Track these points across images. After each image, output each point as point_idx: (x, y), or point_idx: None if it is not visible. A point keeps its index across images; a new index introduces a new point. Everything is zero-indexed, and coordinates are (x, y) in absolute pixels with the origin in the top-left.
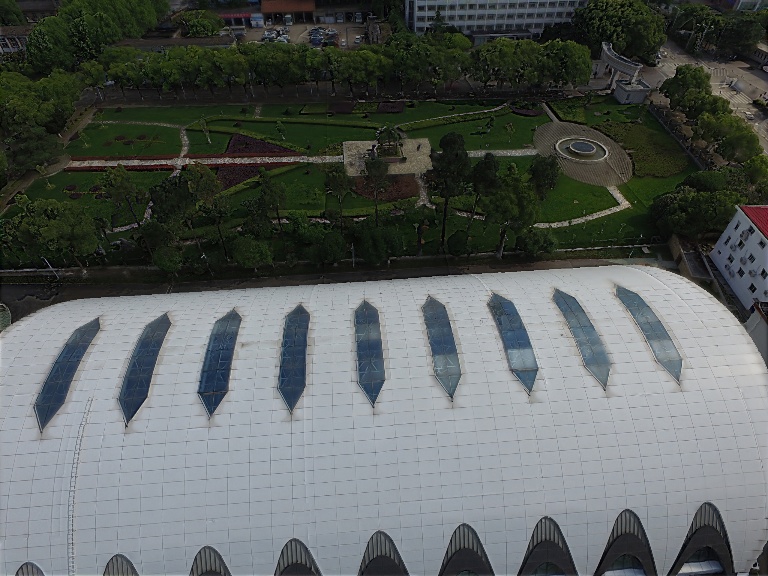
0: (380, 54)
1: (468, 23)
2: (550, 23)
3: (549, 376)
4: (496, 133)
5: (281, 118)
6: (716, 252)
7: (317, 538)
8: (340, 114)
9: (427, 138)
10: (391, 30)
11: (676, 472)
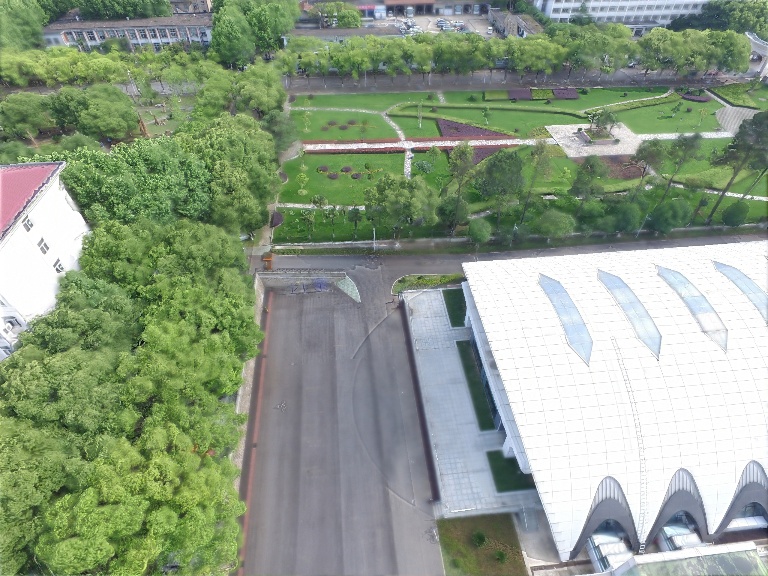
0: (556, 43)
1: (600, 14)
2: (676, 15)
3: None
4: (680, 117)
5: (468, 104)
6: None
7: None
8: (522, 100)
9: (621, 122)
10: (535, 21)
11: None
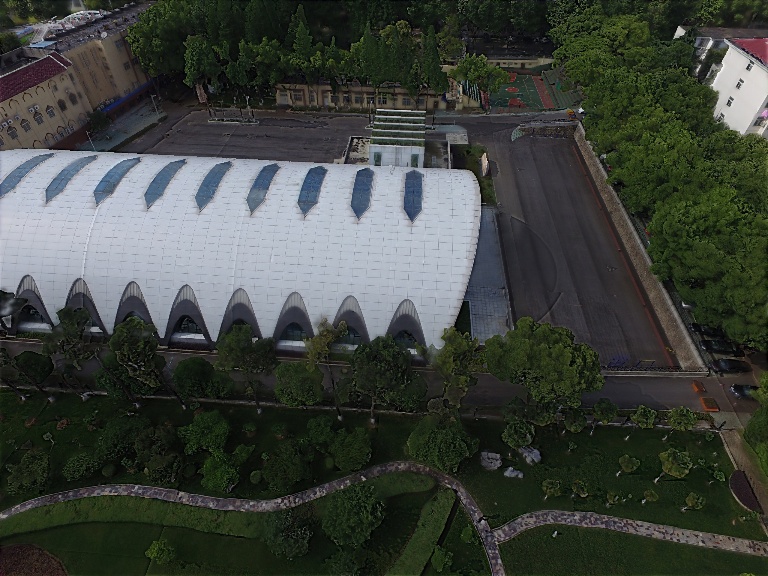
0: None
1: None
2: None
3: None
4: None
5: None
6: None
7: None
8: None
9: None
10: None
11: None
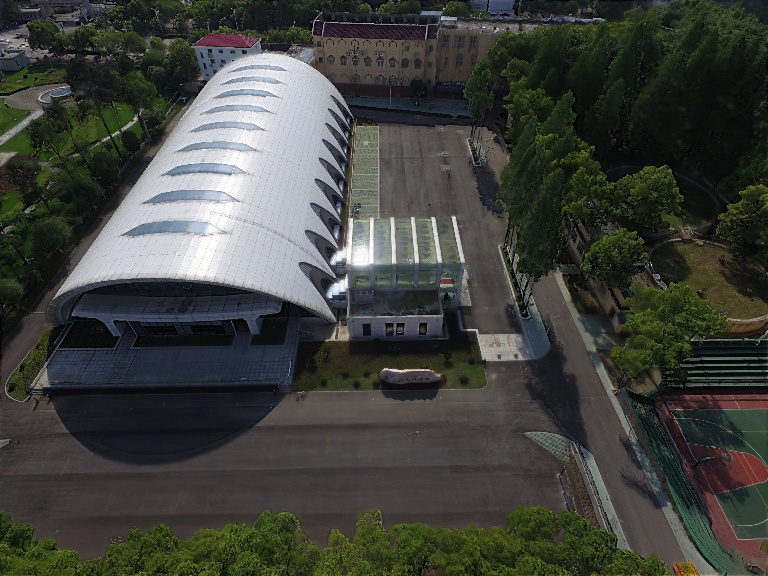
0: None
1: None
2: None
3: (272, 91)
4: None
5: None
6: (206, 76)
7: (316, 174)
8: None
9: None
10: None
11: (320, 92)
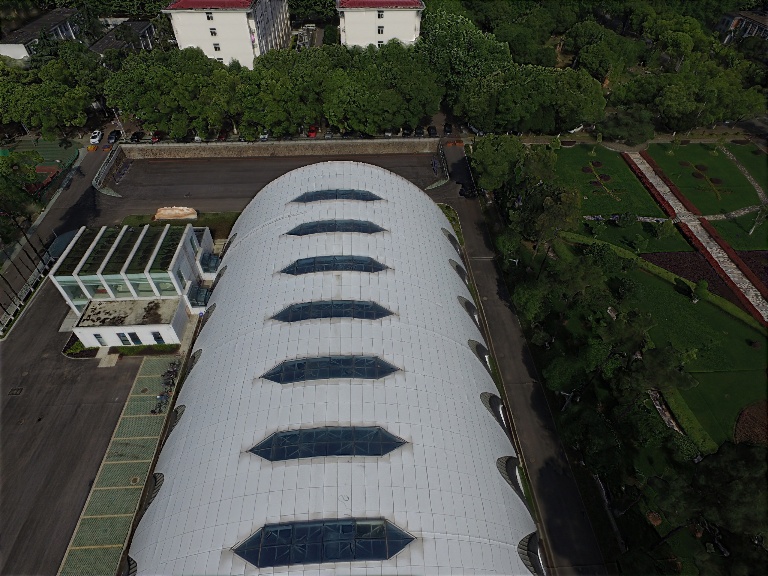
0: None
1: None
2: None
3: None
4: None
5: None
6: None
7: None
8: None
9: None
10: None
11: None
